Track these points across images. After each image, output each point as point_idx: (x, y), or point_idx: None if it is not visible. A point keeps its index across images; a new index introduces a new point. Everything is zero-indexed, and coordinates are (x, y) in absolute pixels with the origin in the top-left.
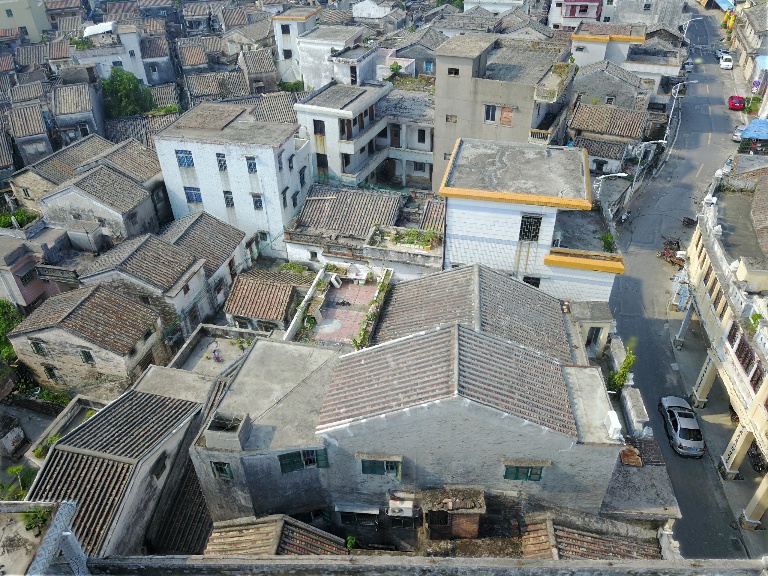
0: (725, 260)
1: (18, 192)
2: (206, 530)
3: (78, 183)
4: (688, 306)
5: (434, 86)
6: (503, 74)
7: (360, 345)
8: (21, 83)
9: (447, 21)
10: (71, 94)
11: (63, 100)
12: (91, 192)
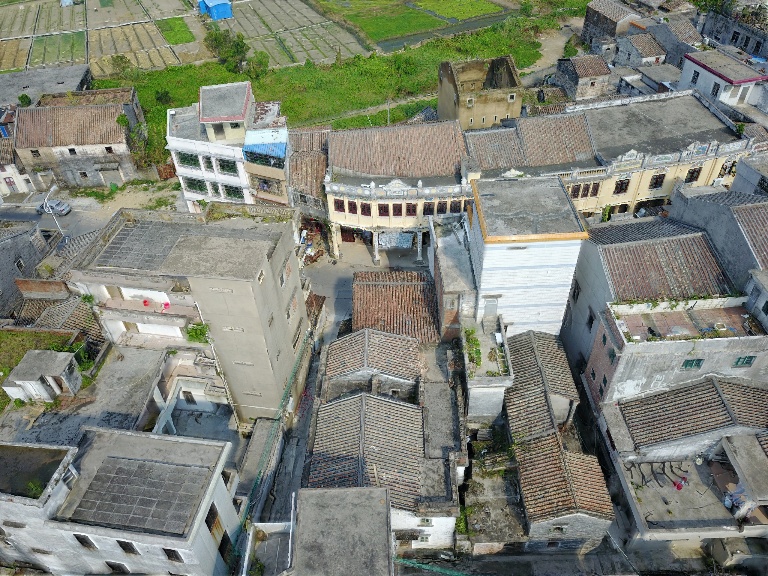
0: (452, 186)
1: None
2: None
3: None
4: (420, 237)
5: None
6: None
7: (703, 298)
8: None
9: None
10: None
11: None
12: None
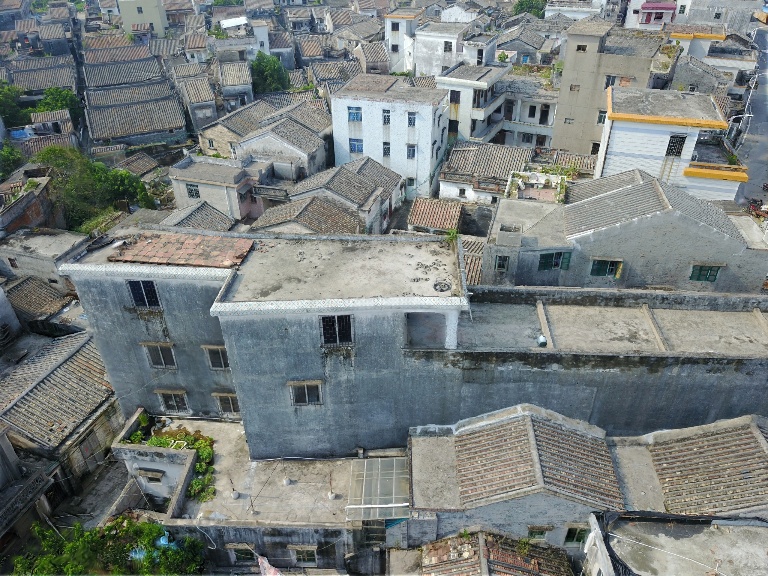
0: None
1: (204, 143)
2: None
3: (273, 129)
4: None
5: (537, 73)
6: (619, 53)
7: None
8: (167, 67)
9: (534, 24)
10: (234, 70)
11: (228, 74)
12: (284, 136)
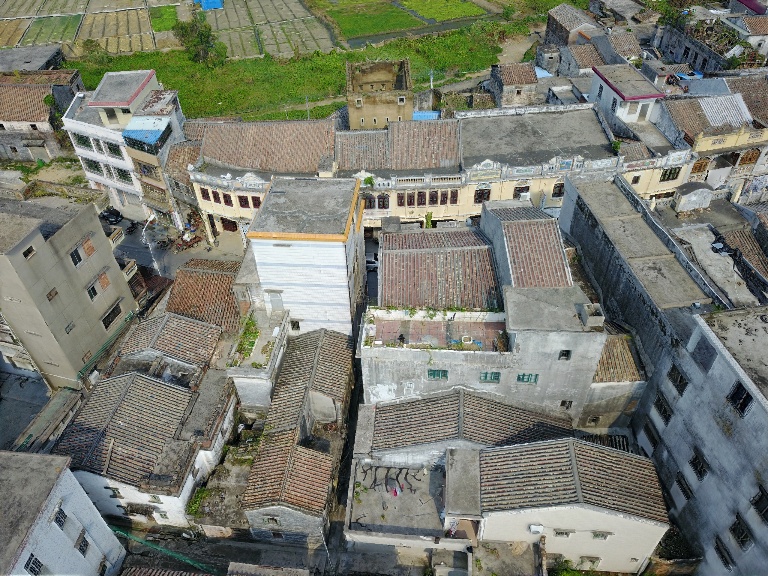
0: None
1: None
2: (562, 436)
3: None
4: None
5: None
6: None
7: None
8: None
9: None
10: None
11: None
12: None
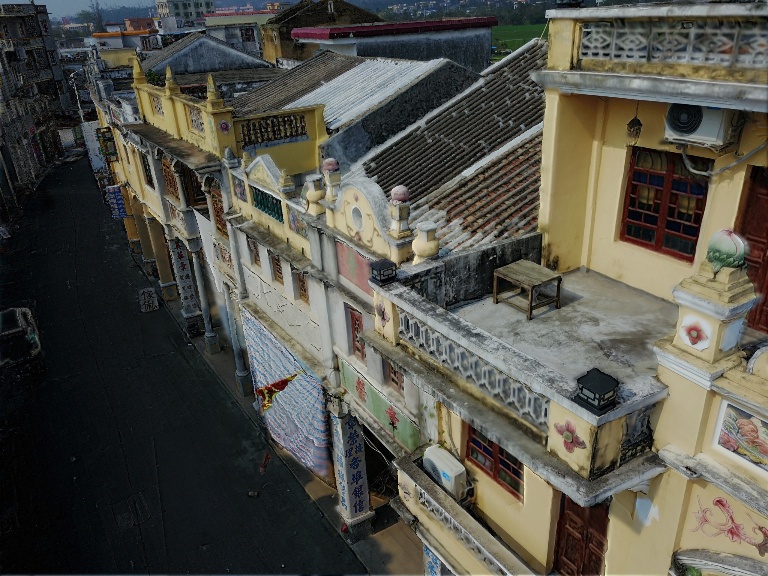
0: None
1: None
2: None
3: None
4: None
5: None
6: None
7: None
8: None
9: None
10: None
11: None
12: None
